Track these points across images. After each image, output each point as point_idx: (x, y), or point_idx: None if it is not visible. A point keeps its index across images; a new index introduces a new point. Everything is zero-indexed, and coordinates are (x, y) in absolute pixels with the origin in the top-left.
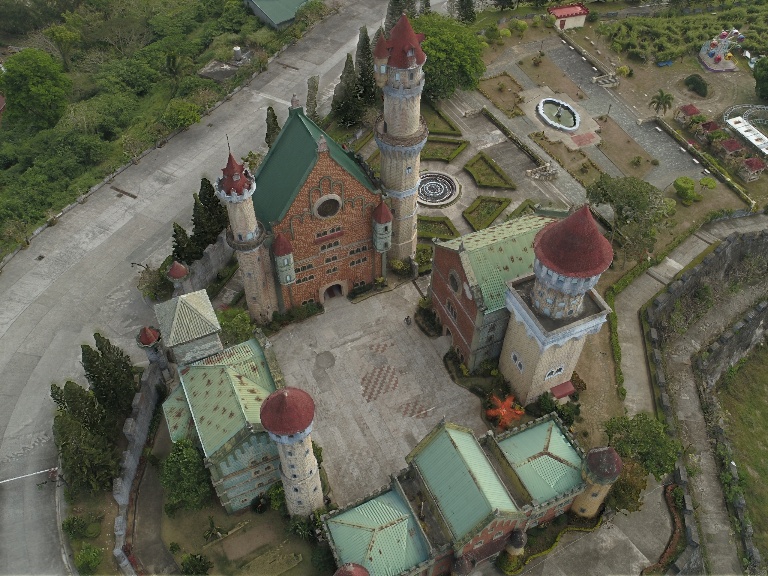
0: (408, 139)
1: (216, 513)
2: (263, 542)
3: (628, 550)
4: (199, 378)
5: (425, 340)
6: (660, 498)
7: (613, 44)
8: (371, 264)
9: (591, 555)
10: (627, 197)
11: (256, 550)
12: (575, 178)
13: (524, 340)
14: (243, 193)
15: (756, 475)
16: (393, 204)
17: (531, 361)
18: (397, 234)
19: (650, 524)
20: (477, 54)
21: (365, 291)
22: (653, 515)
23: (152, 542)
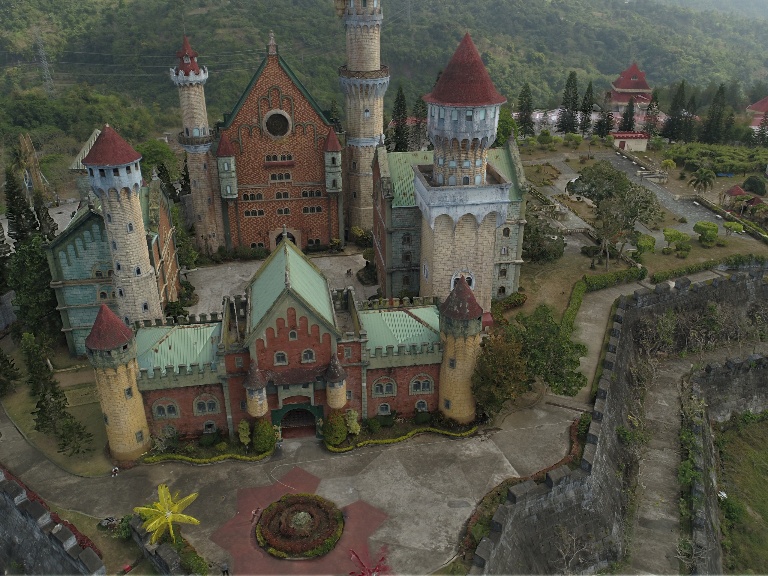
0: (363, 72)
1: (62, 356)
2: (88, 381)
3: (496, 462)
4: None
5: (358, 286)
6: (564, 430)
7: None
8: (327, 219)
9: (445, 457)
10: (602, 176)
11: (76, 385)
12: (587, 222)
13: (427, 233)
14: (189, 74)
15: (758, 517)
16: (354, 156)
17: (431, 254)
18: (359, 195)
19: (538, 447)
20: (510, 126)
21: (319, 251)
22: (546, 441)
23: None
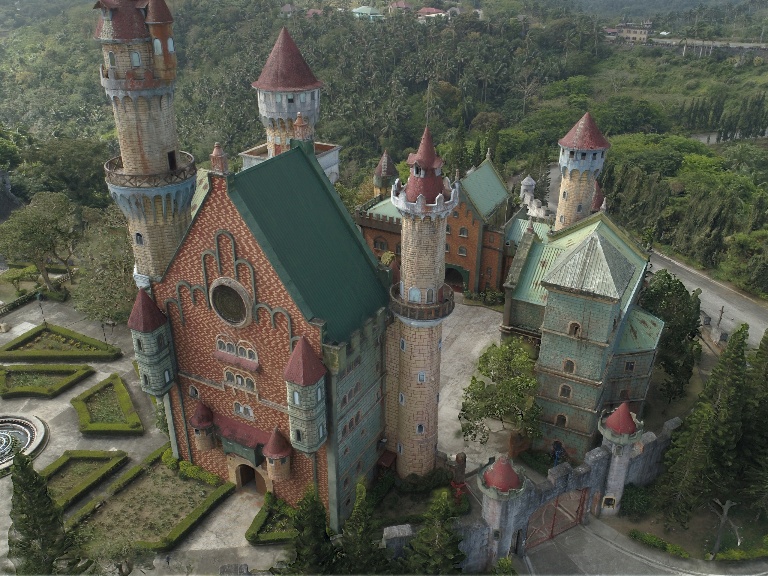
0: None
1: None
2: None
3: None
4: None
5: None
6: None
7: None
8: None
9: None
10: None
11: None
12: None
13: None
14: None
15: None
16: None
17: None
18: None
19: None
20: None
21: None
22: None
23: None
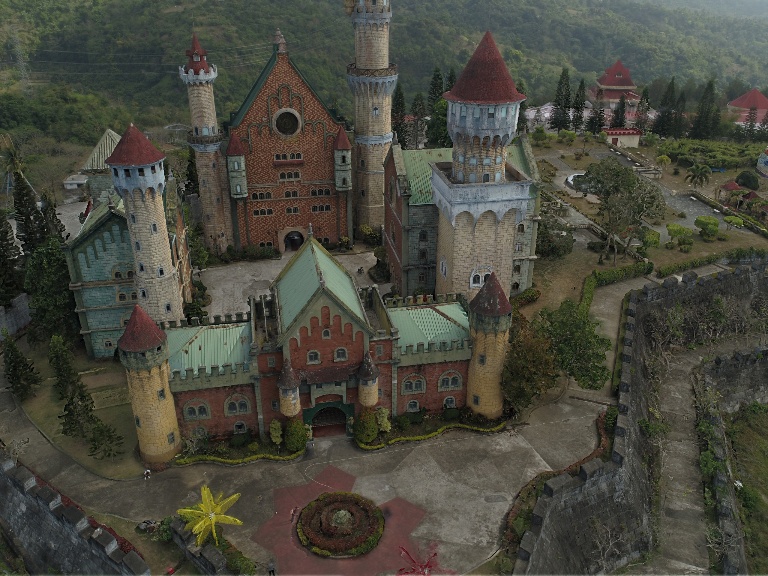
0: (372, 70)
1: (79, 358)
2: (109, 383)
3: (528, 456)
4: (102, 206)
5: None
6: (590, 423)
7: (660, 148)
8: (336, 217)
9: (477, 452)
10: (609, 172)
11: (97, 388)
12: (588, 217)
13: (446, 230)
14: (199, 72)
15: None
16: (362, 154)
17: (450, 252)
18: (367, 193)
19: (567, 441)
20: None
21: (328, 249)
22: (575, 435)
23: (3, 370)
